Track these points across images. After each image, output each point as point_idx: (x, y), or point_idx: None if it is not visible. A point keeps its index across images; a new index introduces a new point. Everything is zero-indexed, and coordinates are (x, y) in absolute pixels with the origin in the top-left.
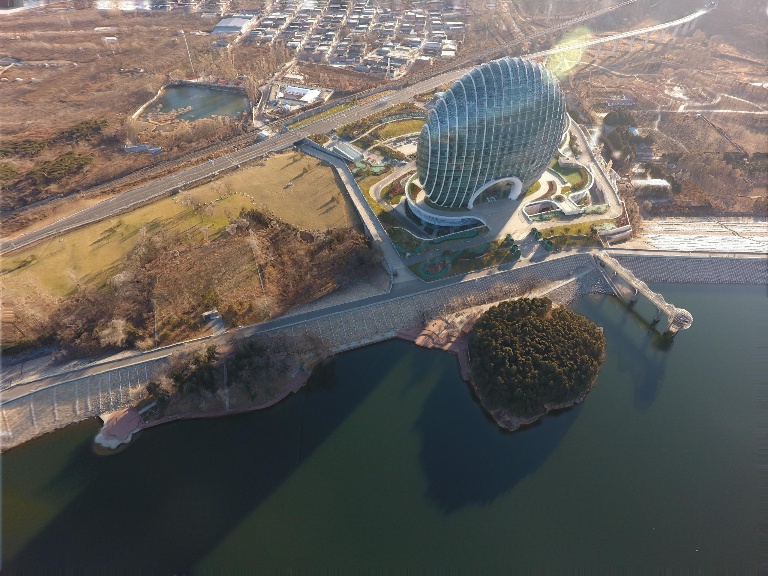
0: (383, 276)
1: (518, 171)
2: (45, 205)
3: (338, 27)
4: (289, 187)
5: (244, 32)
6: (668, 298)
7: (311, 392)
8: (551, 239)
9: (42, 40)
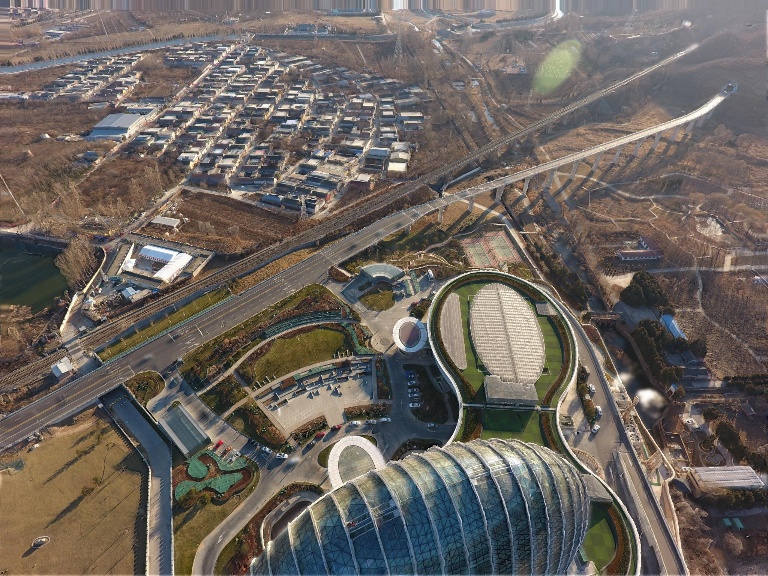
0: None
1: None
2: None
3: (259, 123)
4: (36, 550)
5: (133, 133)
6: None
7: None
8: None
9: None
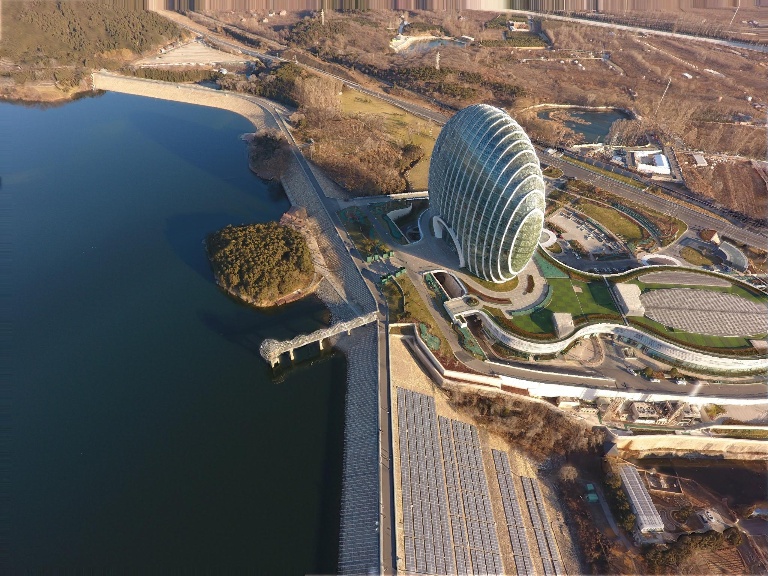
0: None
1: None
2: (416, 95)
3: None
4: None
5: None
6: (323, 380)
7: (267, 191)
8: (396, 285)
9: (651, 57)
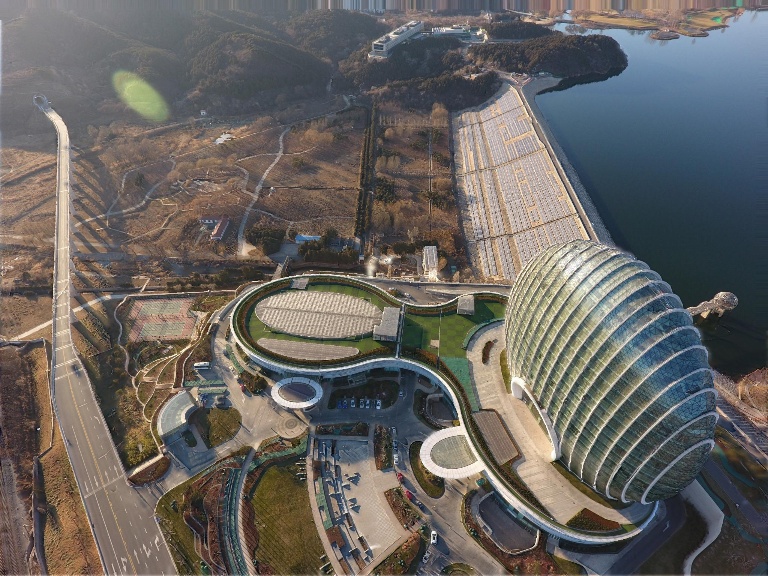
0: None
1: None
2: None
3: None
4: None
5: None
6: None
7: None
8: None
9: None
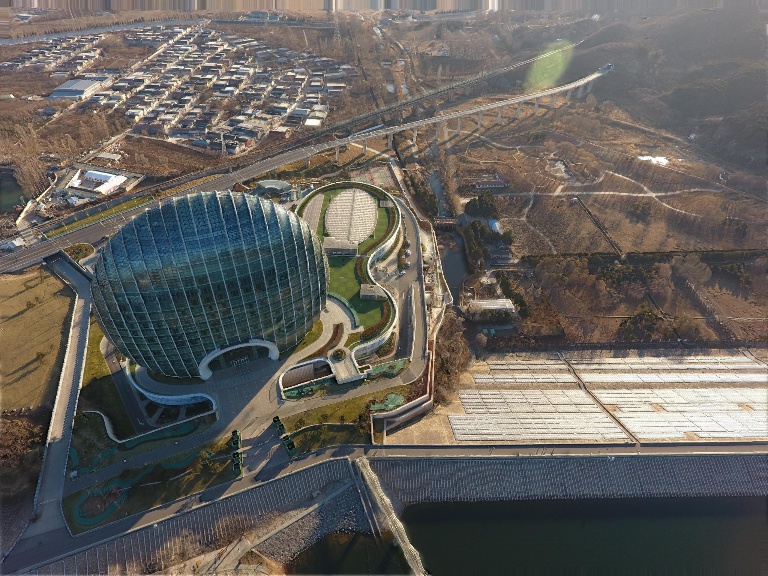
0: (27, 513)
1: (258, 333)
2: None
3: (202, 90)
4: None
5: (89, 96)
6: (449, 534)
7: None
8: (301, 433)
9: None
